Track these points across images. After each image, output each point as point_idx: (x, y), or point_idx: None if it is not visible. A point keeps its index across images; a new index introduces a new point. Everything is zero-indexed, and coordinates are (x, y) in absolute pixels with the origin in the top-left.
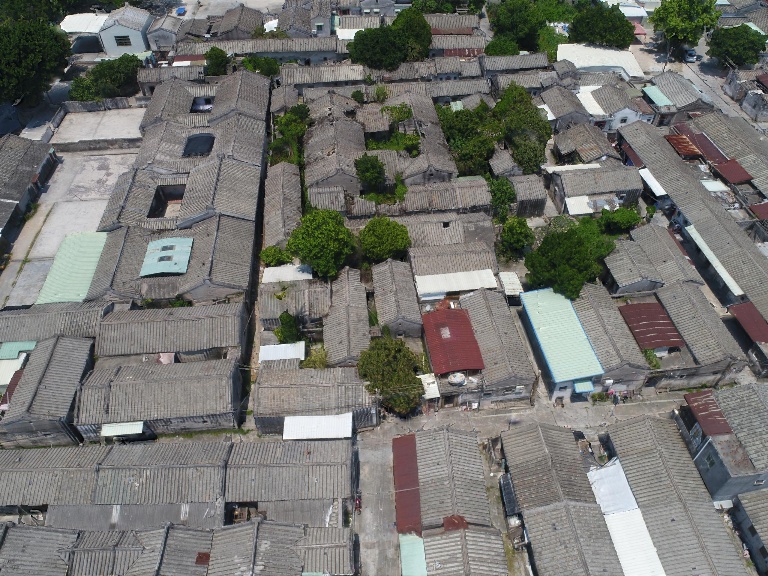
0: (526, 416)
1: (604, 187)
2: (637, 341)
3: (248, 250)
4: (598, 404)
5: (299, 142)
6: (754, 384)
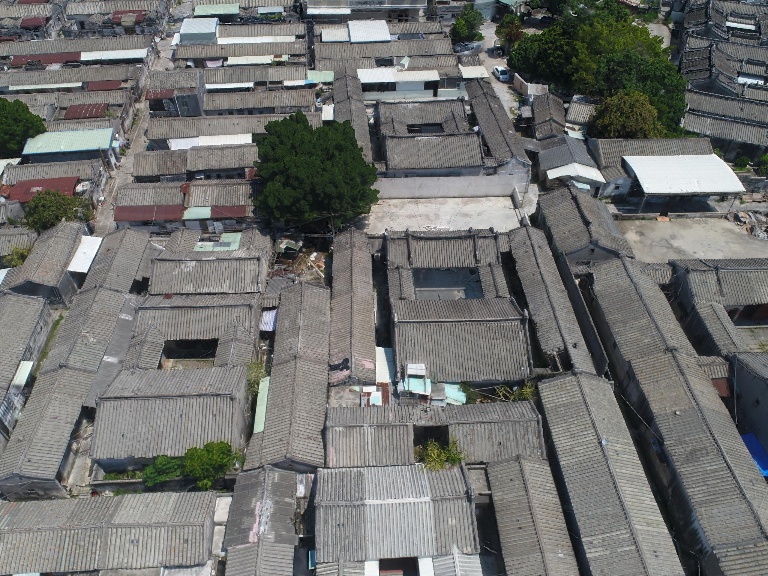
0: (120, 181)
1: None
2: (95, 117)
3: None
4: (126, 154)
5: None
6: None
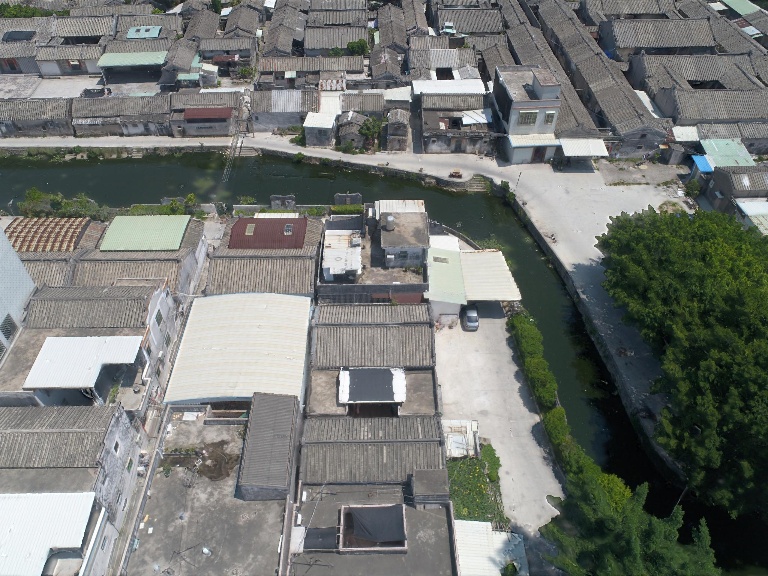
0: None
1: None
2: None
3: None
4: None
5: None
6: None
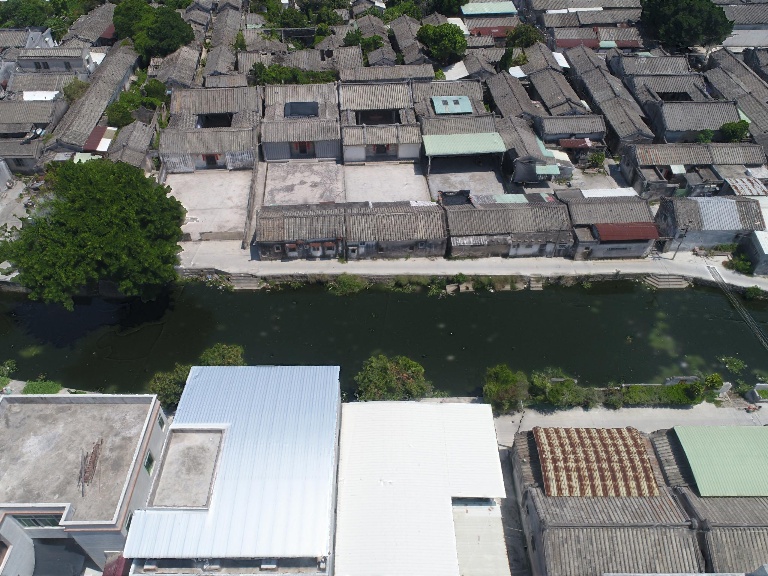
0: None
1: None
2: None
3: None
4: None
5: None
6: None
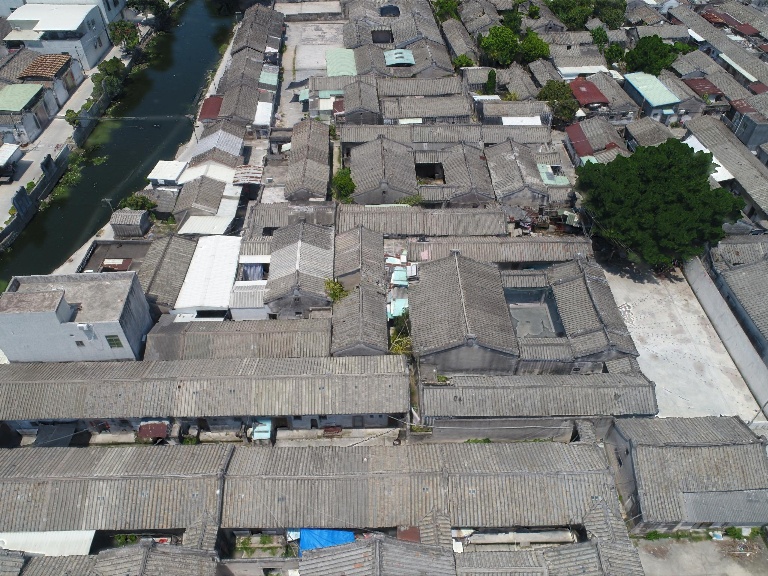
0: None
1: (665, 35)
2: (697, 93)
3: (447, 57)
4: (675, 128)
5: (455, 13)
6: (767, 91)
